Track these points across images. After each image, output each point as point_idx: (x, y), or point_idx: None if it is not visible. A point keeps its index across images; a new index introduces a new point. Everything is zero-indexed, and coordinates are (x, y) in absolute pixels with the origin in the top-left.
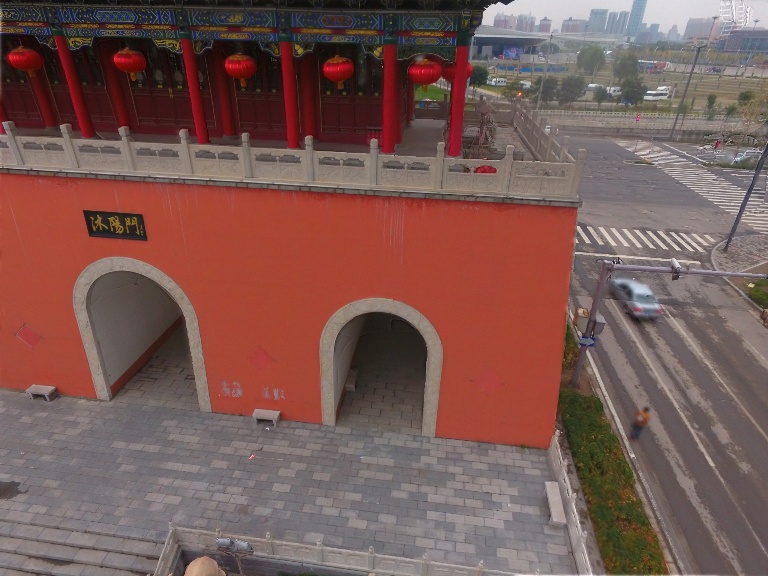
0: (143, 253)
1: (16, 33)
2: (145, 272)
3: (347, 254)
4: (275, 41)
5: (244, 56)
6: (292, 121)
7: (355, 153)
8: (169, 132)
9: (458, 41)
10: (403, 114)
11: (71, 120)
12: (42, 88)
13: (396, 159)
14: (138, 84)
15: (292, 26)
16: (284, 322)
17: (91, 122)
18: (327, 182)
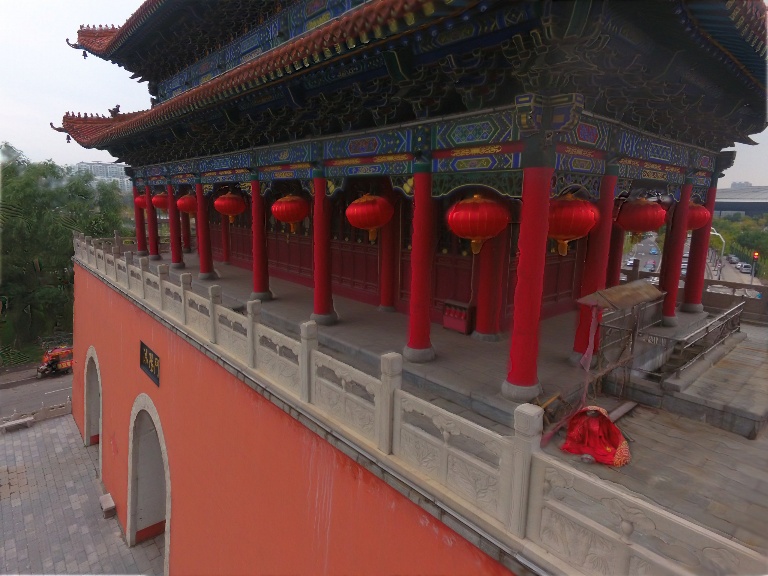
0: (157, 400)
1: (184, 183)
2: (156, 421)
3: (271, 505)
4: (311, 178)
5: (292, 197)
6: (317, 278)
7: (290, 339)
8: (283, 276)
9: (523, 158)
10: (555, 288)
11: (236, 257)
12: (225, 229)
13: (331, 365)
14: (271, 228)
15: (323, 158)
16: (218, 565)
17: (210, 259)
18: (262, 375)
